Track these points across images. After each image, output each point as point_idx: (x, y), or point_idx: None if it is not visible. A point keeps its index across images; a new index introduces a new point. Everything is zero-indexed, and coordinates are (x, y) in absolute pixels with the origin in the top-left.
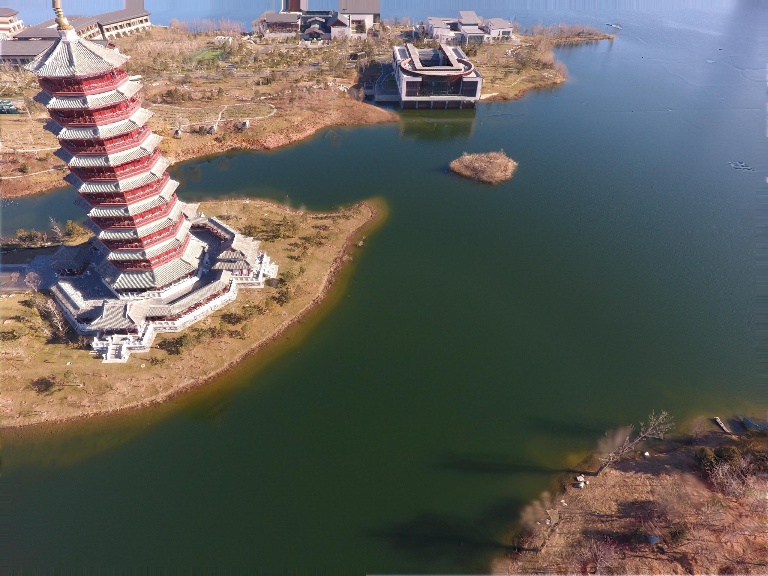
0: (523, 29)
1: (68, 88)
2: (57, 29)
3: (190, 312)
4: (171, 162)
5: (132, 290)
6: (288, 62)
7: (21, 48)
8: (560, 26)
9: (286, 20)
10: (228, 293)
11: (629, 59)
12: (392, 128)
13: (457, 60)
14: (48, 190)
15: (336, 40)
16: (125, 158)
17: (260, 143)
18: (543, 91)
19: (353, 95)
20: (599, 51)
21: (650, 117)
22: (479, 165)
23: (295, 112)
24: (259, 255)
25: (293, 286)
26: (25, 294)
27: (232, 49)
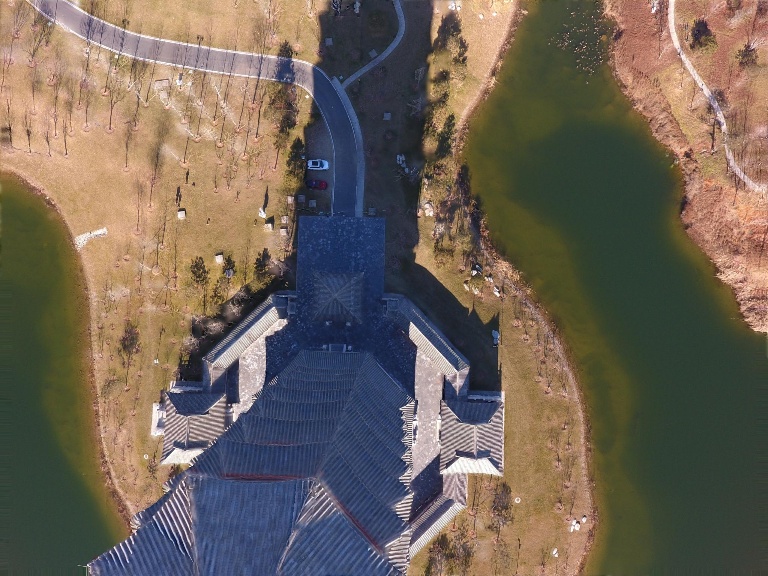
0: None
1: None
2: None
3: None
4: None
5: None
6: None
7: None
8: None
9: None
10: None
11: None
12: None
13: None
14: (639, 113)
15: None
16: None
17: None
18: None
19: None
20: None
21: None
22: None
23: None
24: None
25: None
26: (286, 248)
27: None
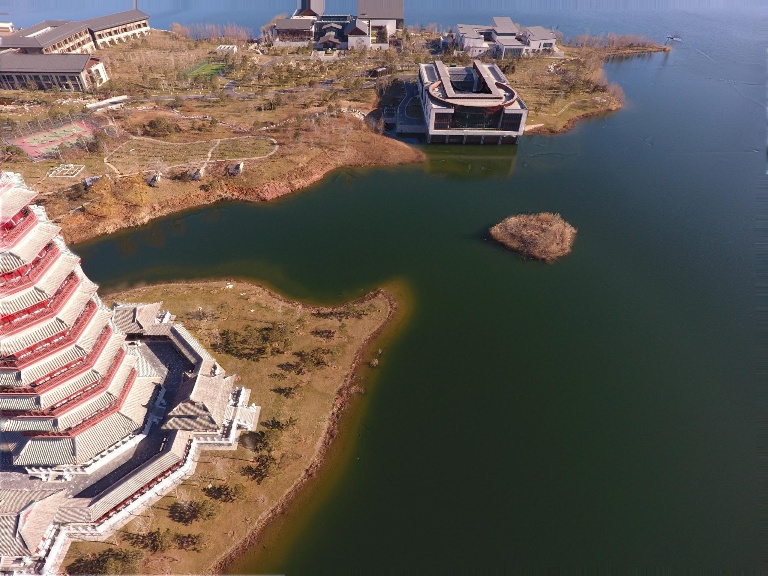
0: (566, 39)
1: None
2: None
3: (122, 508)
4: (143, 221)
5: None
6: (297, 79)
7: None
8: (609, 36)
9: (298, 26)
10: (183, 467)
11: (693, 78)
12: (417, 171)
13: (496, 85)
14: None
15: (353, 51)
16: (6, 309)
17: (255, 193)
18: (594, 118)
19: (371, 127)
20: (652, 65)
21: (733, 161)
22: (528, 233)
23: (300, 150)
24: (235, 390)
25: (278, 449)
26: None
27: (234, 63)
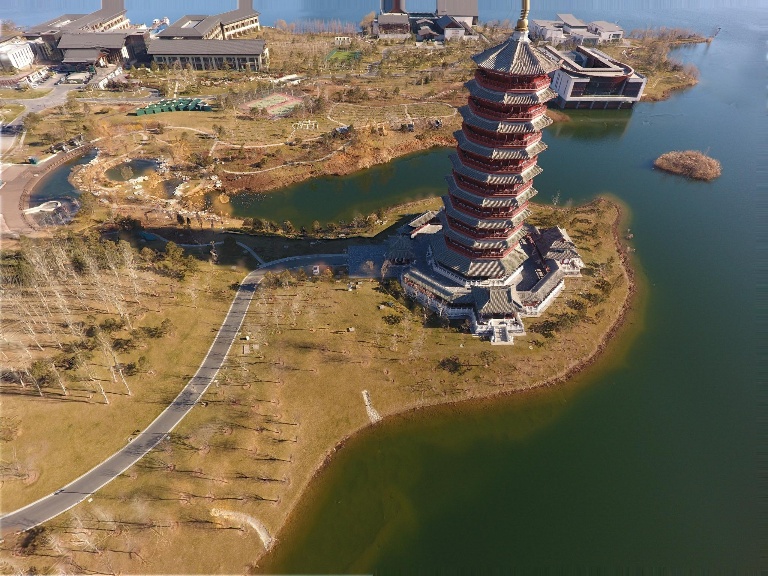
0: None
1: (523, 85)
2: (518, 30)
3: (545, 298)
4: None
5: (477, 278)
6: (423, 62)
7: (182, 47)
8: (661, 29)
9: (398, 21)
10: (563, 281)
11: (742, 62)
12: (567, 127)
13: (611, 62)
14: (289, 185)
15: (452, 41)
16: (533, 152)
17: None
18: (676, 92)
19: None
20: None
21: None
22: (687, 163)
23: None
24: None
25: (610, 275)
26: (370, 282)
27: (368, 49)
